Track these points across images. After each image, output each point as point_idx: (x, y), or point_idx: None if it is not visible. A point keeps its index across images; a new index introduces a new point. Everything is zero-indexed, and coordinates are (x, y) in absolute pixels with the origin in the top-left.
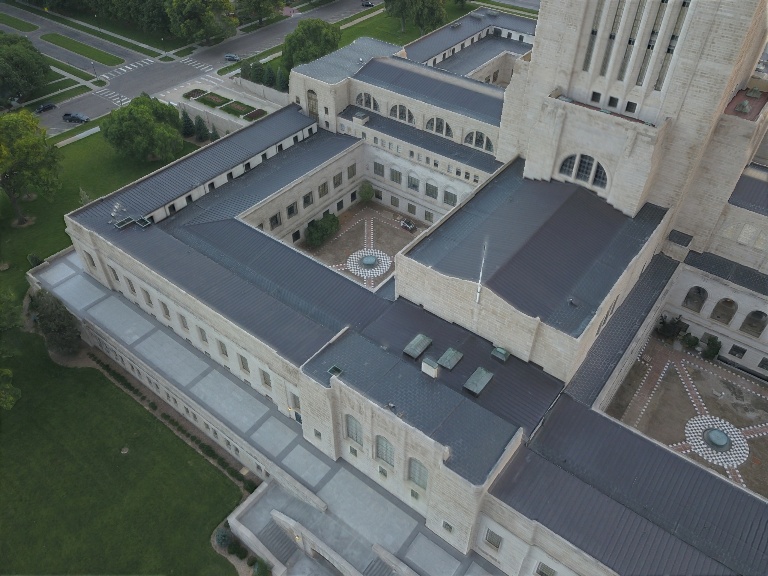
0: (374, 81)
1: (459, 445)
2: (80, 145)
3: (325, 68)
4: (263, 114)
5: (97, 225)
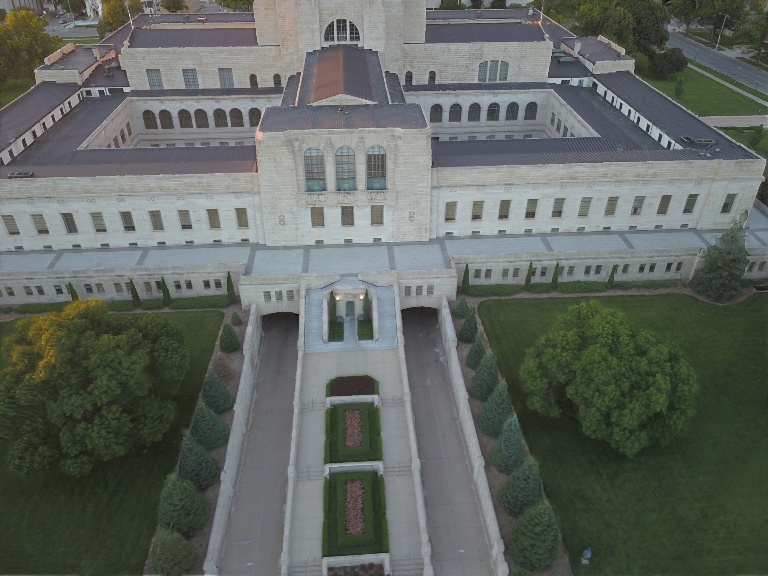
0: (377, 95)
1: (590, 41)
2: (739, 562)
3: (389, 119)
4: (343, 377)
5: (732, 151)
